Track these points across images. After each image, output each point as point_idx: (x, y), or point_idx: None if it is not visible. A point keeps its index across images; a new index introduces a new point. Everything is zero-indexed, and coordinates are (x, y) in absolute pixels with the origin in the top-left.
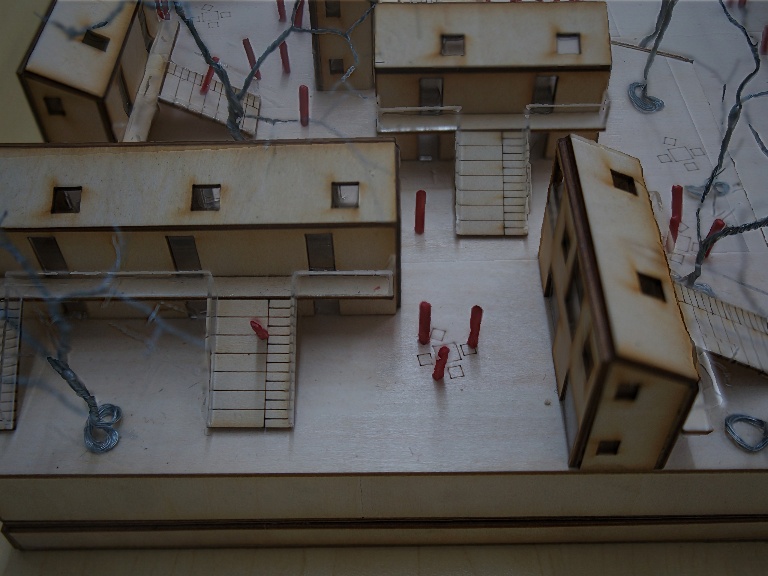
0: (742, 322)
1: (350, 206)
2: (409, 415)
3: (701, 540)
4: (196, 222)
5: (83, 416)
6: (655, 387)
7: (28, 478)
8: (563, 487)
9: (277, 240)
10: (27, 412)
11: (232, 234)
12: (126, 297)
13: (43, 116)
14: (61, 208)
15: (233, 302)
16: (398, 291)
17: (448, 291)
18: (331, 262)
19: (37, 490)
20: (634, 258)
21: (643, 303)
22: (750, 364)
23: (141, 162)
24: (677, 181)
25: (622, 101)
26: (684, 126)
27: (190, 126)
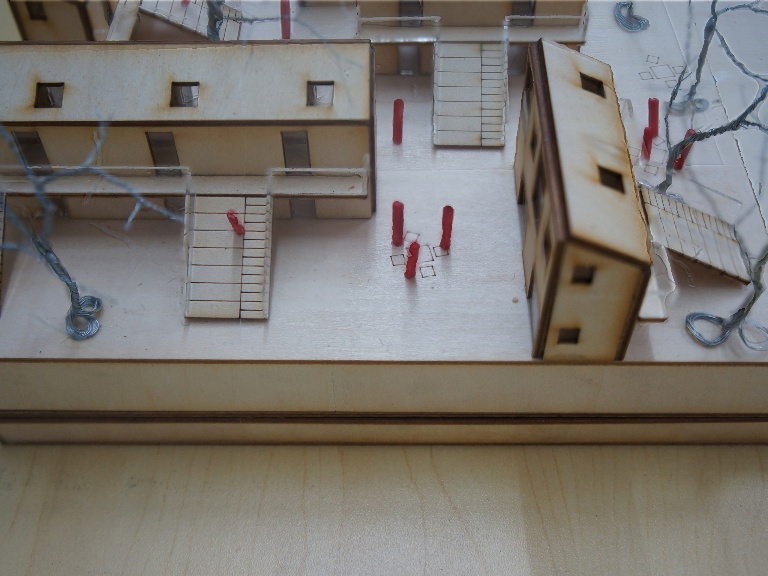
0: (708, 227)
1: (325, 104)
2: (380, 310)
3: (666, 442)
4: (175, 118)
5: (65, 307)
6: (609, 269)
7: (12, 362)
8: (528, 379)
9: (254, 137)
10: (10, 302)
11: (210, 130)
12: (107, 193)
13: (25, 21)
14: (44, 103)
15: (211, 199)
16: (373, 194)
17: (423, 198)
18: (307, 162)
19: (20, 375)
20: (596, 153)
21: (601, 193)
22: (712, 264)
23: (122, 60)
24: (657, 97)
25: (607, 20)
26: (668, 45)
27: (171, 38)
